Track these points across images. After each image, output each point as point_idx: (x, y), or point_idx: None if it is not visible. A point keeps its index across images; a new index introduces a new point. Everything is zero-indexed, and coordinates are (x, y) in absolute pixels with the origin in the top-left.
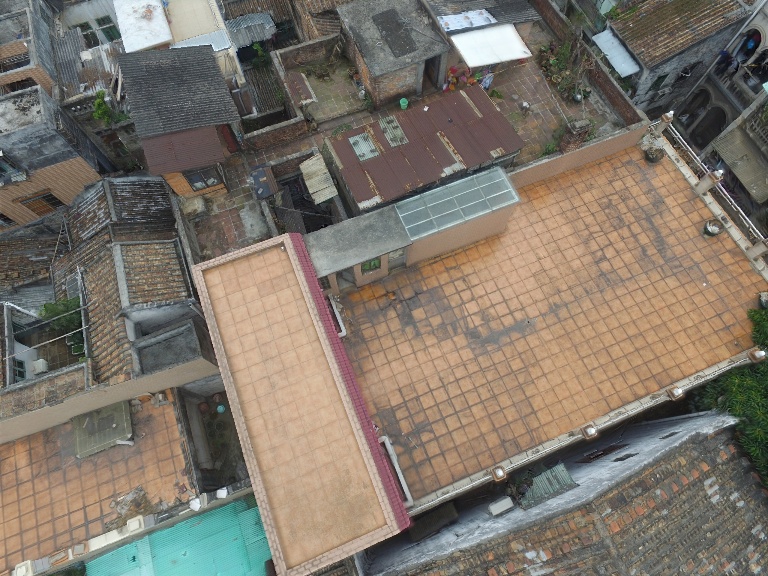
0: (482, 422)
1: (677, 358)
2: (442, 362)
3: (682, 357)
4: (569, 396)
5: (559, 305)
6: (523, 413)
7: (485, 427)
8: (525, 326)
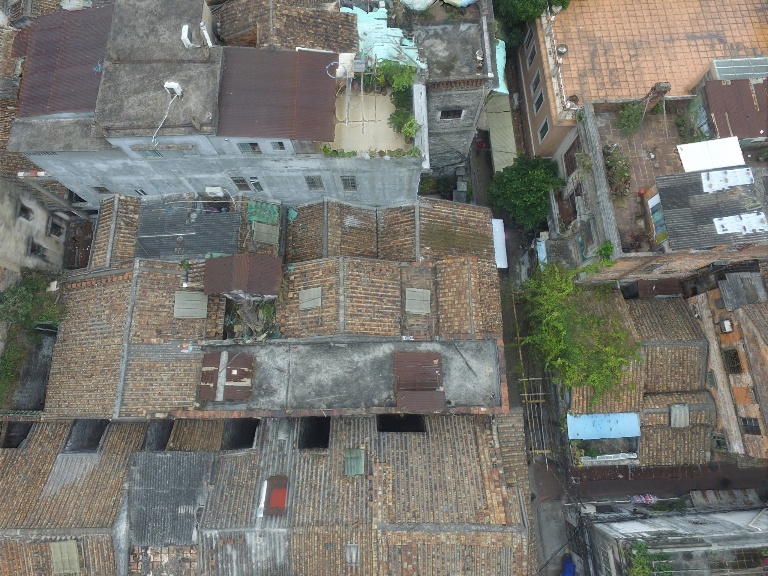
0: (728, 4)
1: (615, 2)
2: (743, 33)
3: (612, 1)
4: (679, 2)
5: (668, 41)
6: (706, 2)
7: (727, 2)
8: (691, 37)
